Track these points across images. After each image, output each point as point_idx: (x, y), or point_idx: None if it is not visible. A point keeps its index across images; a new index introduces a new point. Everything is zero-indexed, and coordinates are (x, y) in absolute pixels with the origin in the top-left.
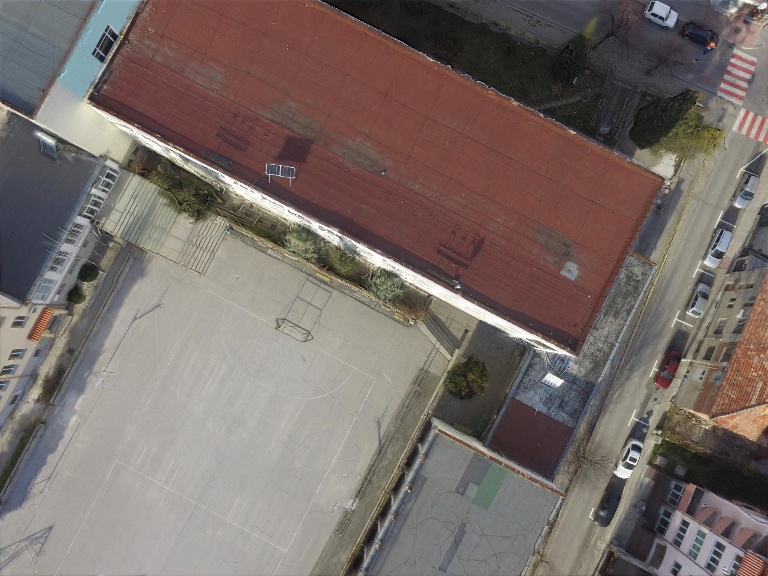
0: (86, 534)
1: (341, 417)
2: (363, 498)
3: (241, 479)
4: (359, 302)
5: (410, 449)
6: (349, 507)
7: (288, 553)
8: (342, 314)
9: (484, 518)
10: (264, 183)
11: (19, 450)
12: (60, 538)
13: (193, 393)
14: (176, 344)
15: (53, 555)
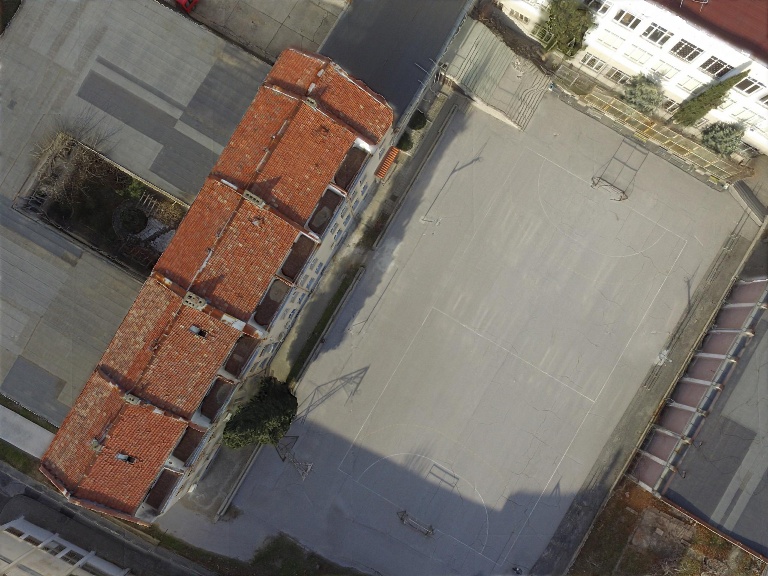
0: (401, 376)
1: (652, 276)
2: (671, 355)
3: (553, 331)
4: (673, 165)
5: (718, 310)
6: (657, 363)
7: (596, 404)
8: (656, 176)
9: None
10: (674, 7)
11: (343, 290)
12: (376, 378)
13: (509, 245)
14: (493, 197)
15: (368, 394)
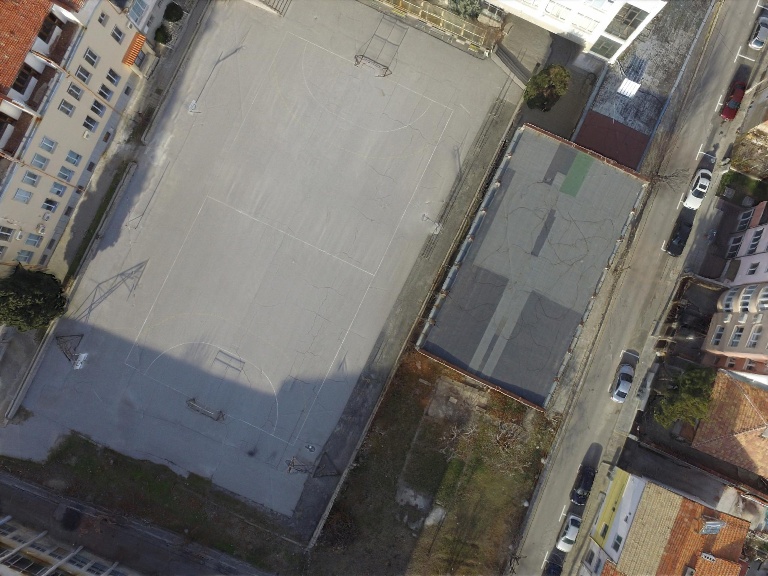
0: (181, 266)
1: (422, 147)
2: (446, 223)
3: (328, 209)
4: (434, 37)
5: (490, 175)
6: (433, 232)
7: (376, 278)
8: (418, 50)
9: (572, 205)
10: None
11: (114, 185)
12: (156, 271)
13: (278, 129)
14: (259, 83)
15: (150, 287)
